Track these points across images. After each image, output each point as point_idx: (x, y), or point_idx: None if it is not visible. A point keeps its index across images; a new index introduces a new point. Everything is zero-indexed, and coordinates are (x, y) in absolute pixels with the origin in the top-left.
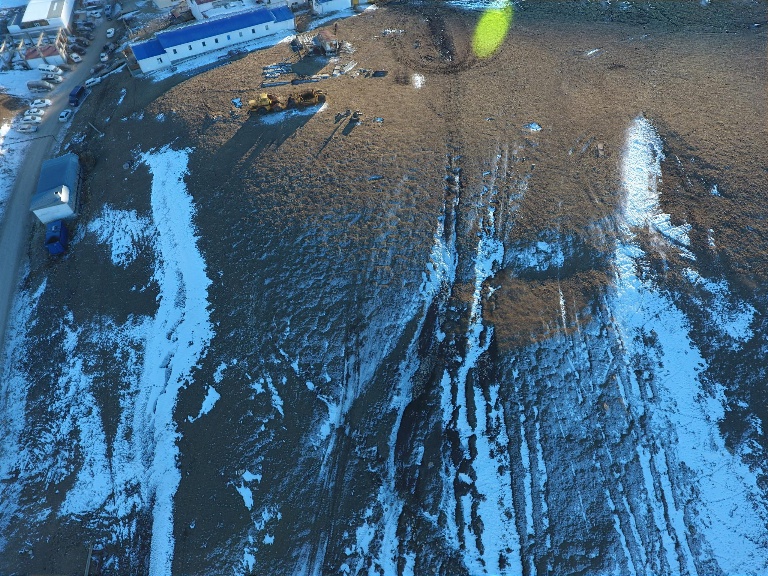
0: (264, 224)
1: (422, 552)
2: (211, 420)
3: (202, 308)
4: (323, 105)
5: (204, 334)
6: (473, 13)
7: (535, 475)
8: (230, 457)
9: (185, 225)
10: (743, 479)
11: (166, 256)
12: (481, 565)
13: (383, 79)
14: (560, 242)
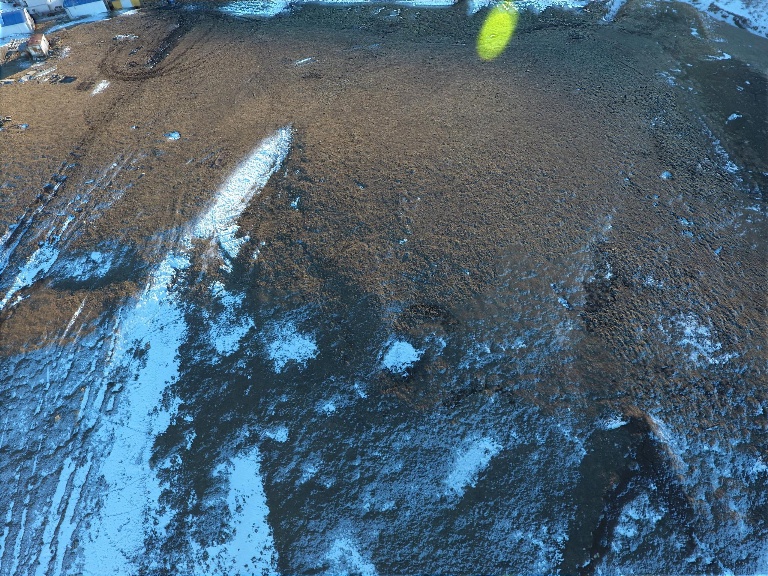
0: None
1: None
2: None
3: None
4: None
5: None
6: (234, 19)
7: None
8: None
9: None
10: (149, 494)
11: None
12: None
13: (66, 85)
14: (114, 252)
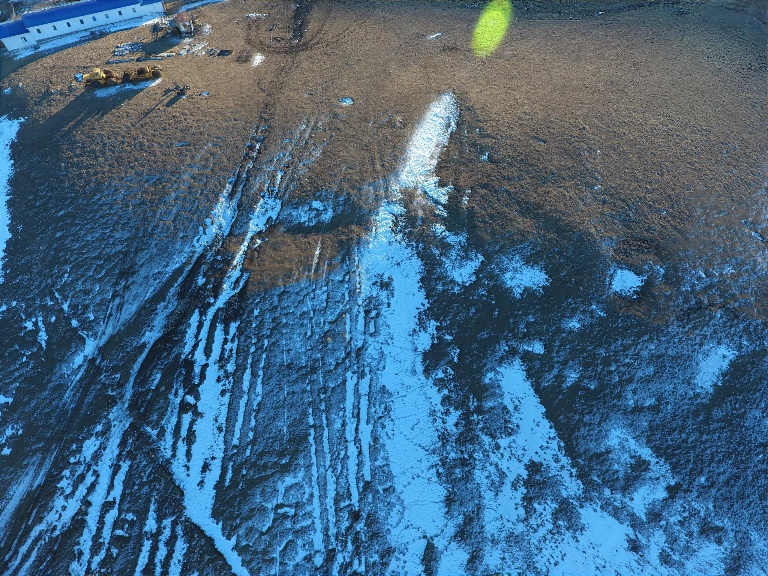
0: (69, 185)
1: (136, 460)
2: None
3: None
4: (157, 80)
5: None
6: None
7: (251, 396)
8: None
9: (1, 186)
10: (430, 399)
11: None
12: (186, 470)
13: (225, 58)
14: (333, 201)
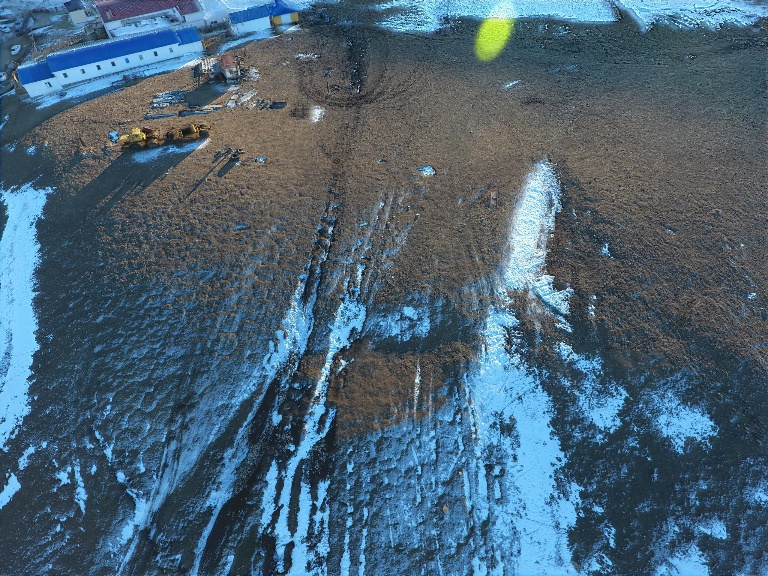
0: (108, 280)
1: None
2: (4, 516)
3: (23, 378)
4: (205, 141)
5: (18, 410)
6: (401, 36)
7: None
8: (15, 564)
9: (26, 278)
10: None
11: (1, 313)
12: None
13: (280, 111)
14: (428, 307)
